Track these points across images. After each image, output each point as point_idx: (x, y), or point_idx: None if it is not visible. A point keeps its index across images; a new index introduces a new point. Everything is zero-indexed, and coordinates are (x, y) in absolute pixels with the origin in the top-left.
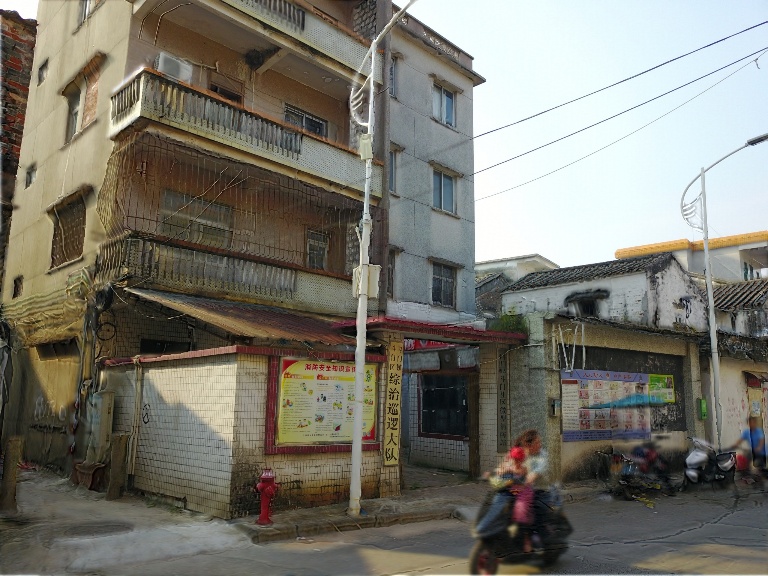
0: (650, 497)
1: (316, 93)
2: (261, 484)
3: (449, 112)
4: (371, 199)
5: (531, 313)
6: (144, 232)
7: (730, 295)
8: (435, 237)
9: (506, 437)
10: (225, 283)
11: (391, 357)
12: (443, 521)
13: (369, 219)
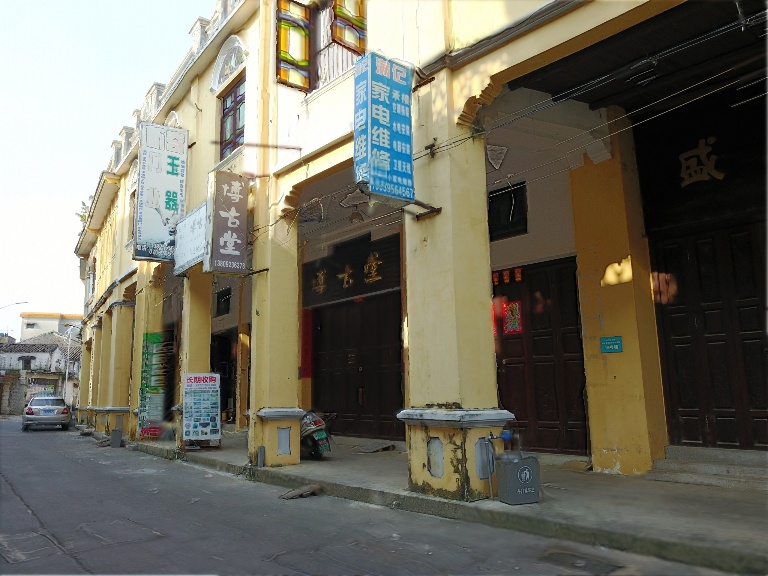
0: None
1: None
2: None
3: None
4: None
5: (23, 370)
6: None
7: (74, 352)
8: None
9: None
10: None
11: None
12: None
13: None
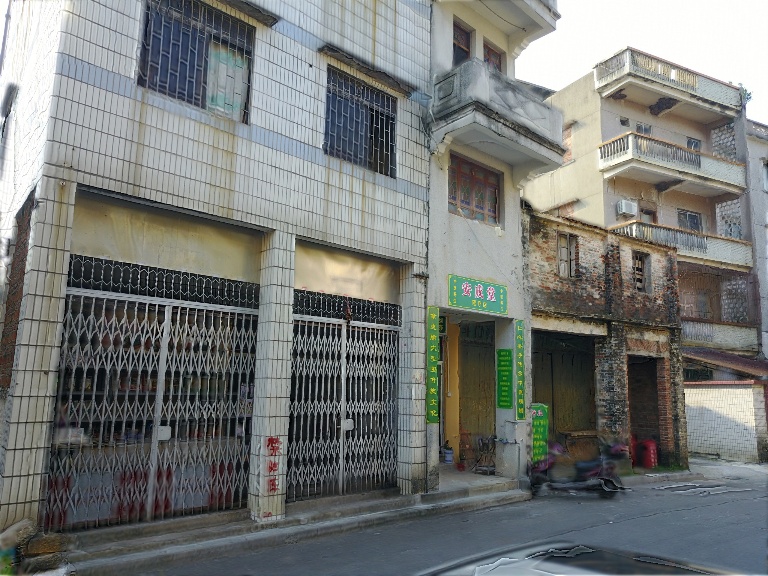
0: None
1: (693, 196)
2: None
3: None
4: None
5: None
6: None
7: None
8: None
9: None
10: None
11: None
12: None
13: None
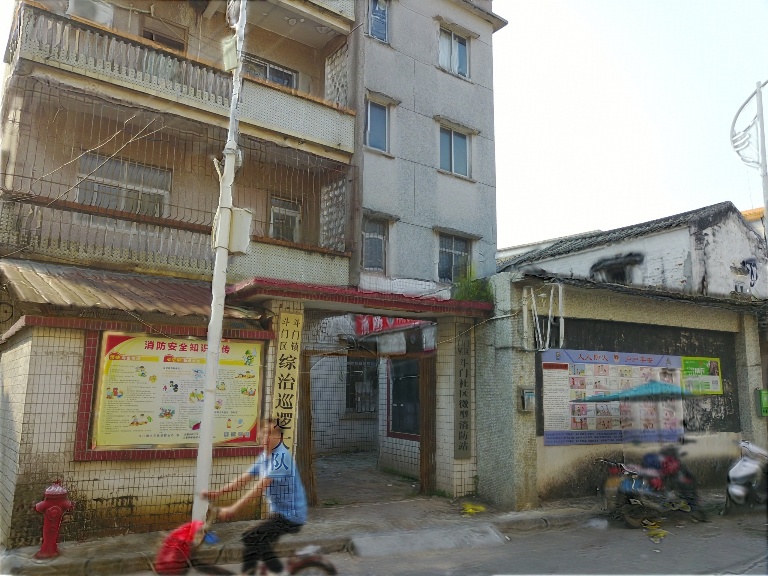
0: (669, 523)
1: (283, 40)
2: (43, 503)
3: (462, 61)
4: (341, 156)
5: (495, 275)
6: (18, 192)
7: None
8: (442, 204)
9: (468, 439)
10: (134, 253)
11: (282, 333)
12: (328, 556)
13: (234, 148)
